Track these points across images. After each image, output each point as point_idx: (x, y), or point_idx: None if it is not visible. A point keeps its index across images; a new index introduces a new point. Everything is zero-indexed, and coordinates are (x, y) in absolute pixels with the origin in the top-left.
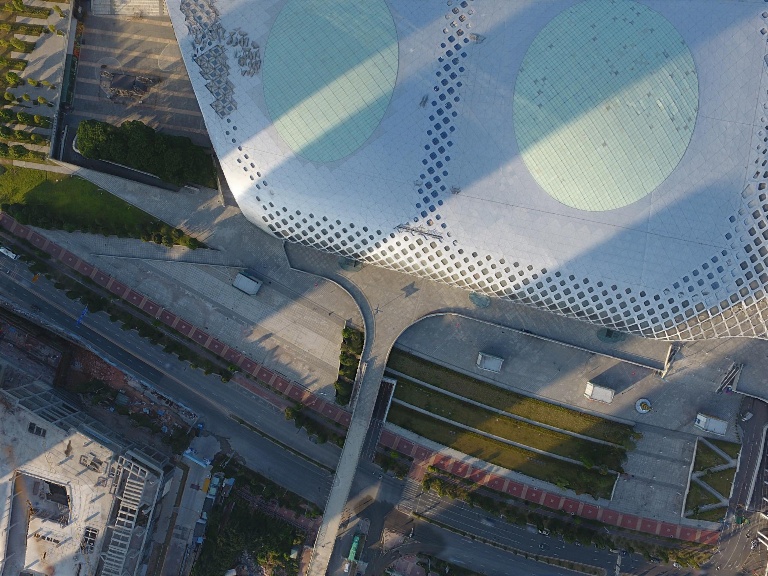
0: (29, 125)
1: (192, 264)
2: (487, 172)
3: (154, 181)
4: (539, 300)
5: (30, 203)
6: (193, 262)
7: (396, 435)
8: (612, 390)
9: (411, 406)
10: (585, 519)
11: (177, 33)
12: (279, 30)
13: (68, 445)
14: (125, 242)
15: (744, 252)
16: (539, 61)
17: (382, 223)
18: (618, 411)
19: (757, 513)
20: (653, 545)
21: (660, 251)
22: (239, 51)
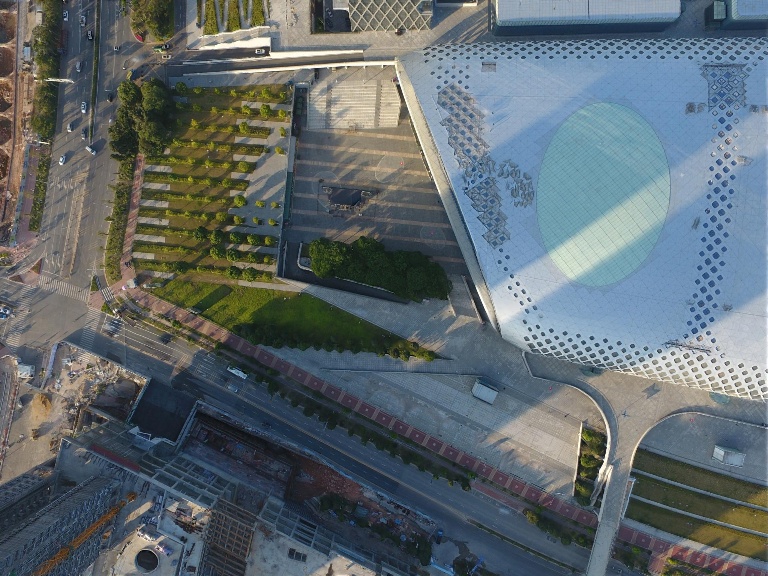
0: (254, 245)
1: (425, 374)
2: (759, 289)
3: (383, 294)
4: None
5: (257, 322)
6: (426, 372)
7: (634, 530)
8: None
9: (648, 501)
10: None
11: (447, 167)
12: (551, 161)
13: (329, 568)
14: (355, 355)
15: None
16: None
17: (651, 340)
18: None
19: None
20: None
21: None
22: (511, 183)
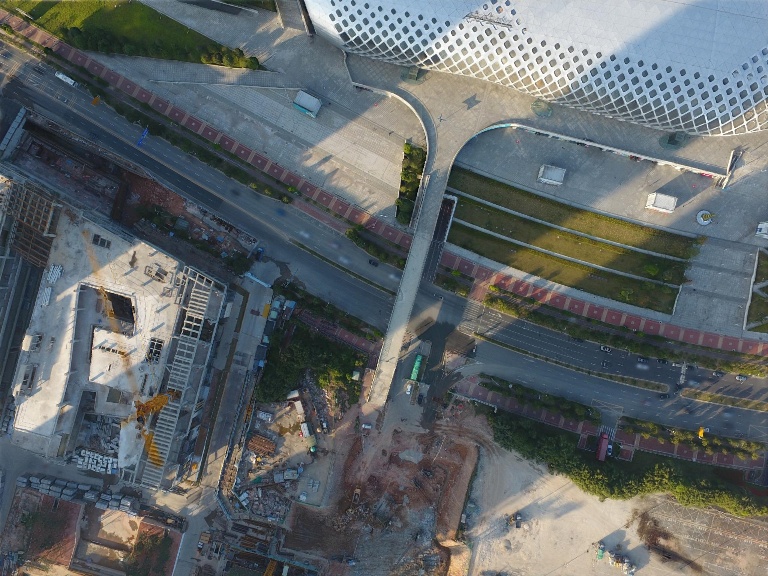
0: None
1: (251, 87)
2: None
3: (213, 5)
4: (606, 94)
5: (88, 30)
6: (252, 85)
7: (457, 256)
8: (675, 197)
9: (472, 225)
10: (647, 335)
11: None
12: None
13: (133, 256)
14: (184, 67)
15: None
16: None
17: (451, 13)
18: (679, 224)
19: None
20: (715, 359)
21: (730, 30)
22: None
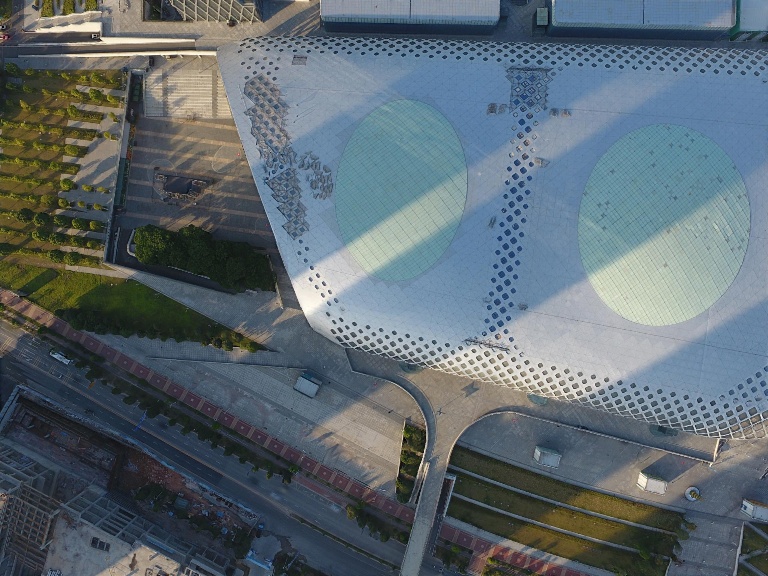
0: (82, 229)
1: (251, 366)
2: (553, 289)
3: (211, 284)
4: (600, 404)
5: (83, 307)
6: (252, 364)
7: (456, 528)
8: (665, 482)
9: (470, 500)
10: None
11: (249, 157)
12: (350, 155)
13: (133, 558)
14: (182, 345)
15: None
16: (602, 185)
17: (451, 337)
18: (669, 499)
19: None
20: None
21: (717, 361)
22: (311, 174)
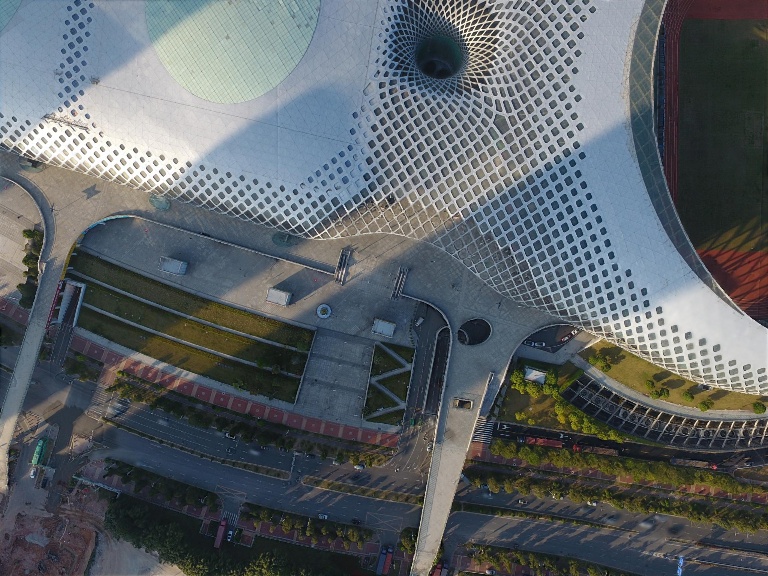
0: None
1: None
2: (124, 63)
3: None
4: (195, 196)
5: None
6: None
7: (87, 340)
8: (286, 293)
9: (101, 311)
10: (271, 423)
11: None
12: None
13: None
14: None
15: (368, 147)
16: None
17: (29, 113)
18: (300, 316)
19: (433, 416)
20: (335, 448)
21: (291, 145)
22: None
